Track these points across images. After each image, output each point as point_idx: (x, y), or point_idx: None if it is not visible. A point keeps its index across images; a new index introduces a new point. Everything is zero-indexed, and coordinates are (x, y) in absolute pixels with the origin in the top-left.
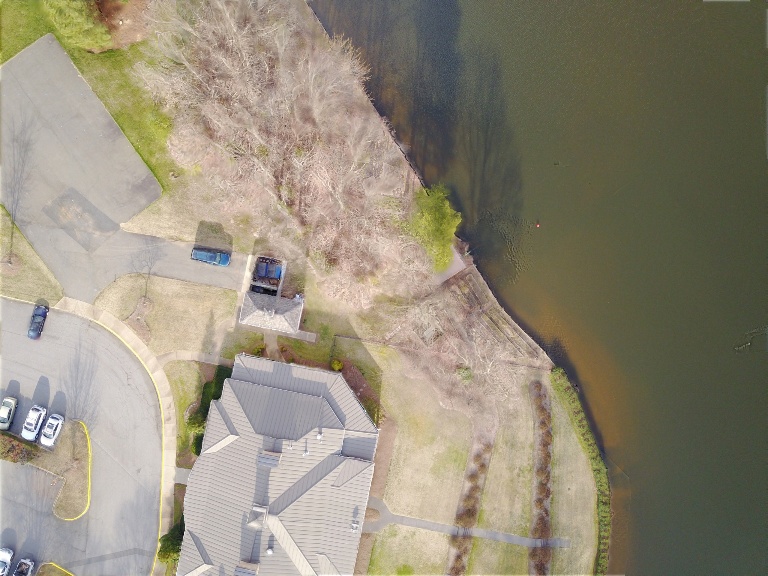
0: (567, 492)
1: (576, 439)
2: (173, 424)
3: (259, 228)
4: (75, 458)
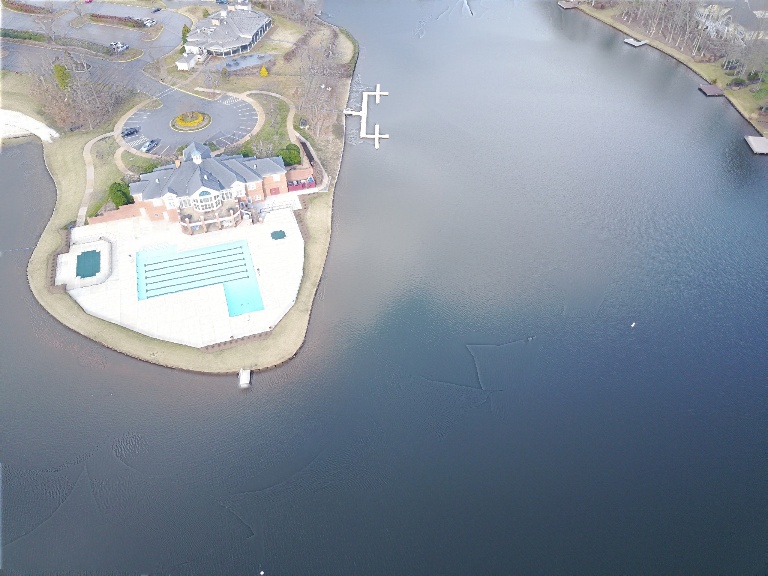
0: (342, 46)
1: (347, 39)
2: None
3: None
4: None
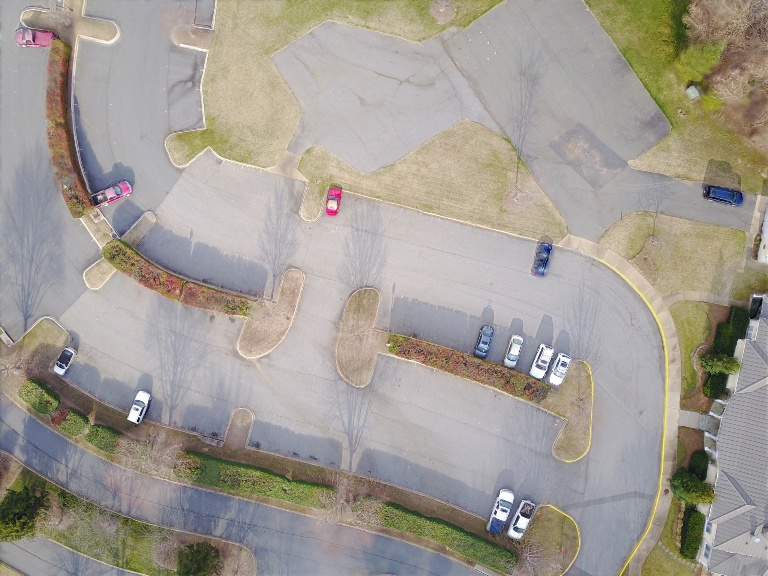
0: None
1: None
2: (678, 366)
3: (766, 168)
4: (580, 398)
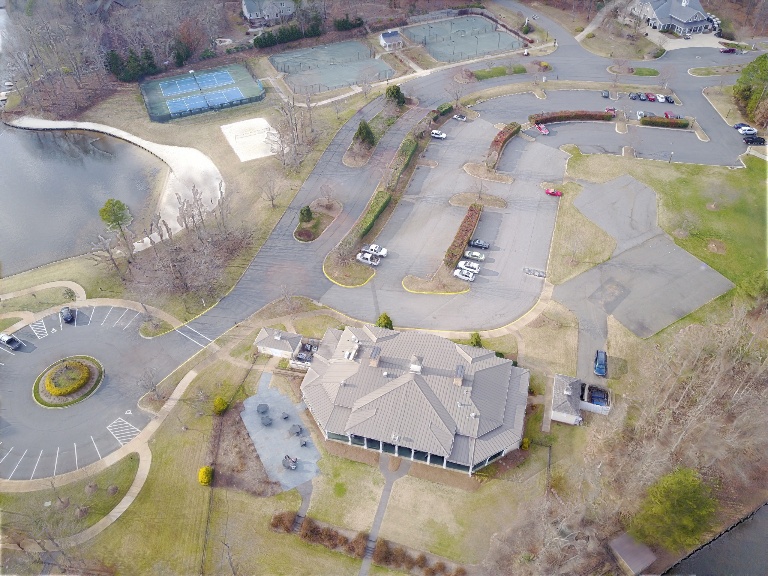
0: None
1: None
2: (469, 337)
3: (630, 398)
4: (445, 286)
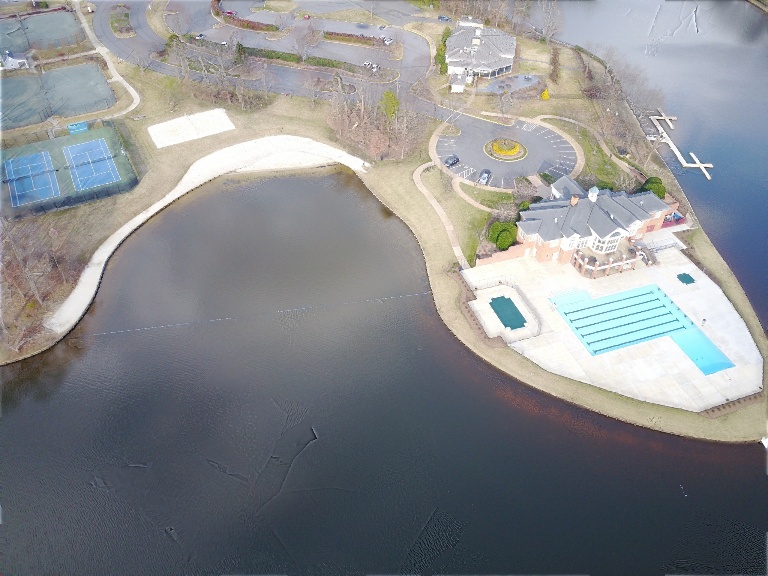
0: None
1: None
2: None
3: None
4: None
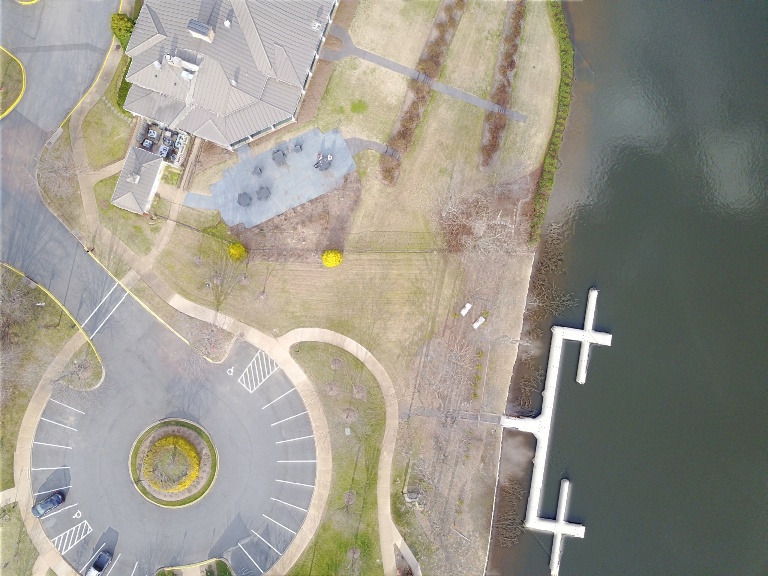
0: (532, 70)
1: (548, 22)
2: None
3: None
4: None
